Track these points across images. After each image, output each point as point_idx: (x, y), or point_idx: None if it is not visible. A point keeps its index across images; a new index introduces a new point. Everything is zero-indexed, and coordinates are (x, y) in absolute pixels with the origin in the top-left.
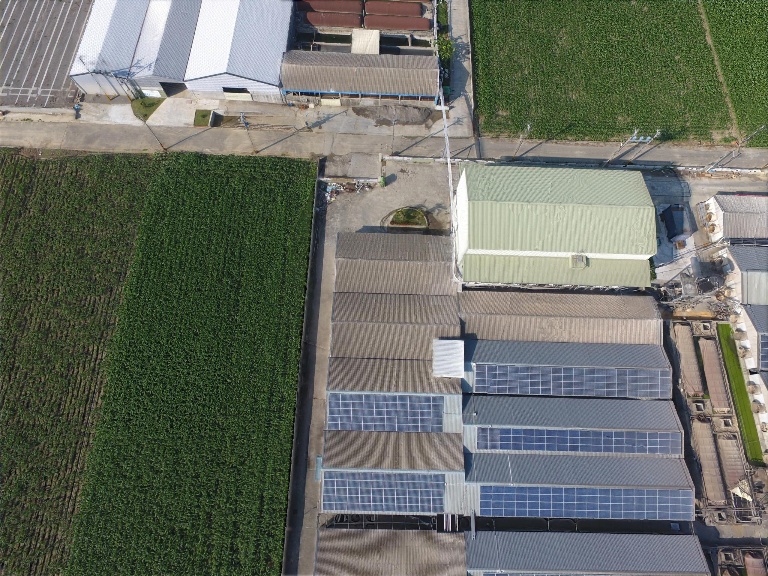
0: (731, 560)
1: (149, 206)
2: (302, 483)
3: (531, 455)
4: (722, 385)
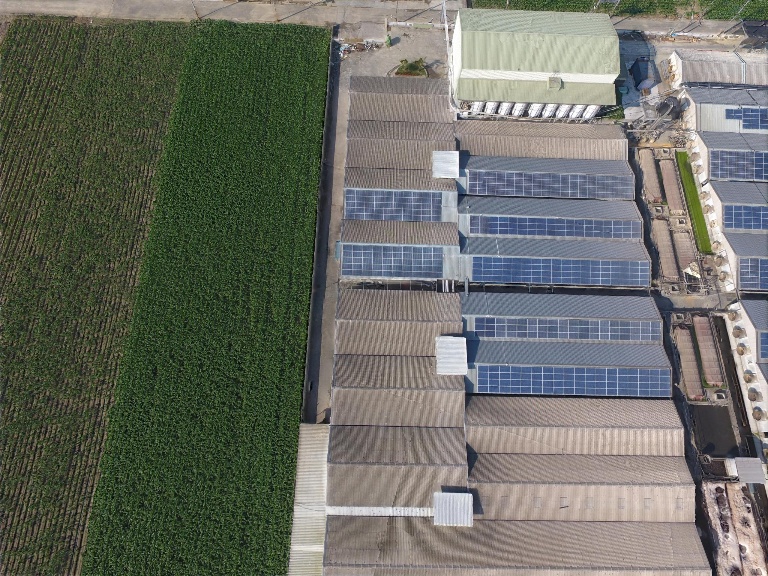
0: (682, 319)
1: (188, 60)
2: (324, 266)
3: (515, 239)
4: (678, 193)
